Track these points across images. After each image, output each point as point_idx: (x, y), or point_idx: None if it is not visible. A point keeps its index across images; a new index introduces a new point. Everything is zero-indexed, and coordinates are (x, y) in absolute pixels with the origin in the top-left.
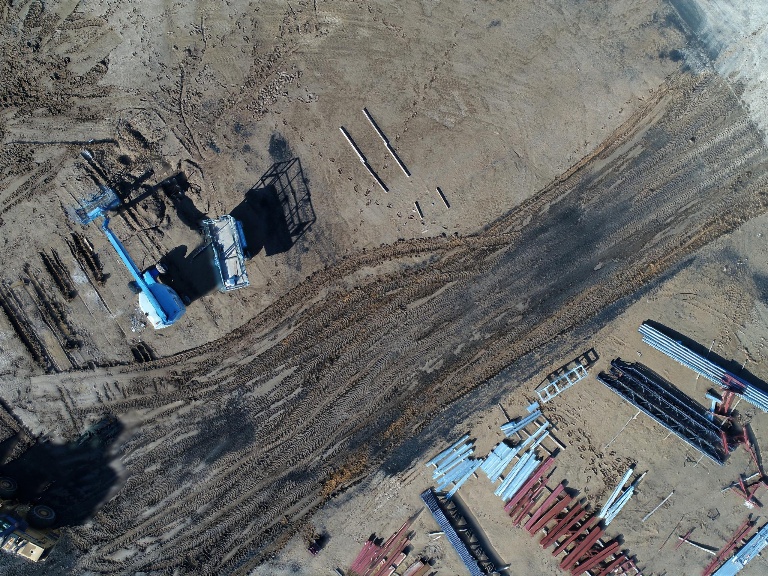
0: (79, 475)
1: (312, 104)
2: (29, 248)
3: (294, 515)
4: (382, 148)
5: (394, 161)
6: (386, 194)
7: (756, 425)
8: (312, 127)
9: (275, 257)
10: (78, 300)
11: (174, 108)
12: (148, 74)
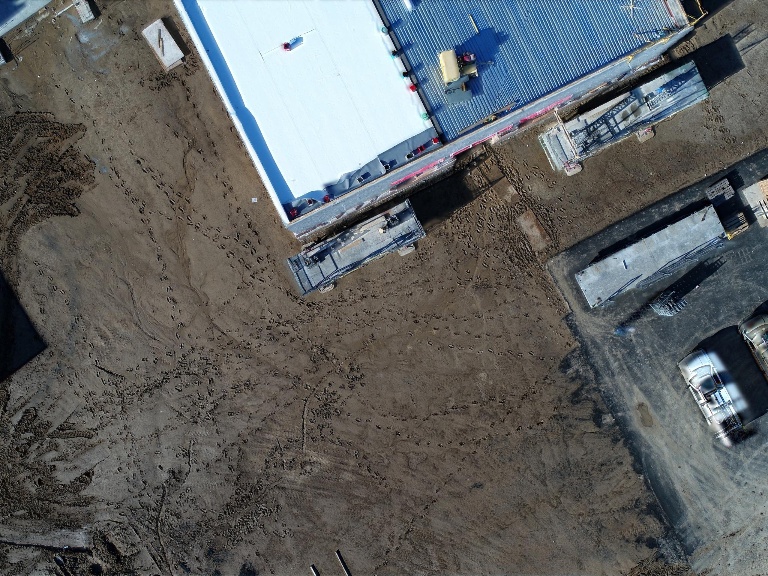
0: None
1: (287, 539)
2: None
3: None
4: None
5: None
6: None
7: None
8: (284, 561)
9: None
10: None
11: (151, 525)
12: (130, 490)
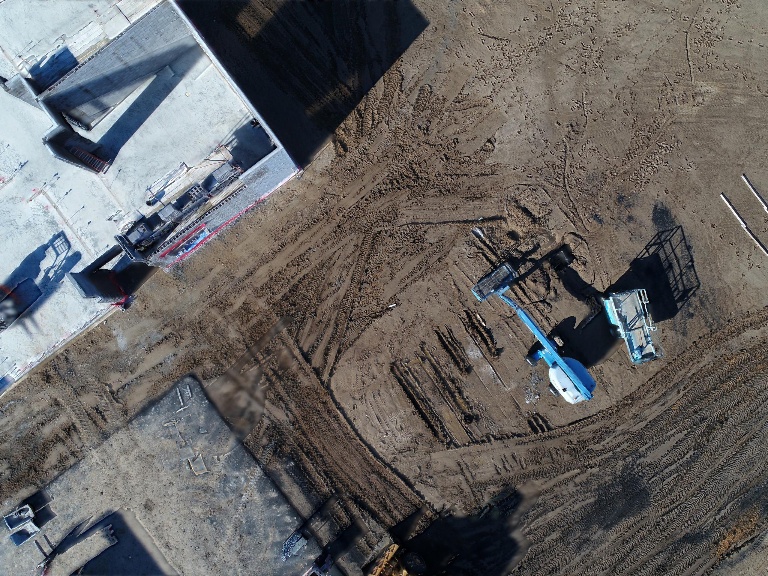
0: (481, 547)
1: (692, 172)
2: (425, 326)
3: None
4: (761, 212)
5: None
6: (767, 257)
7: None
8: (693, 195)
9: (661, 324)
10: (474, 375)
11: (559, 183)
12: (533, 151)
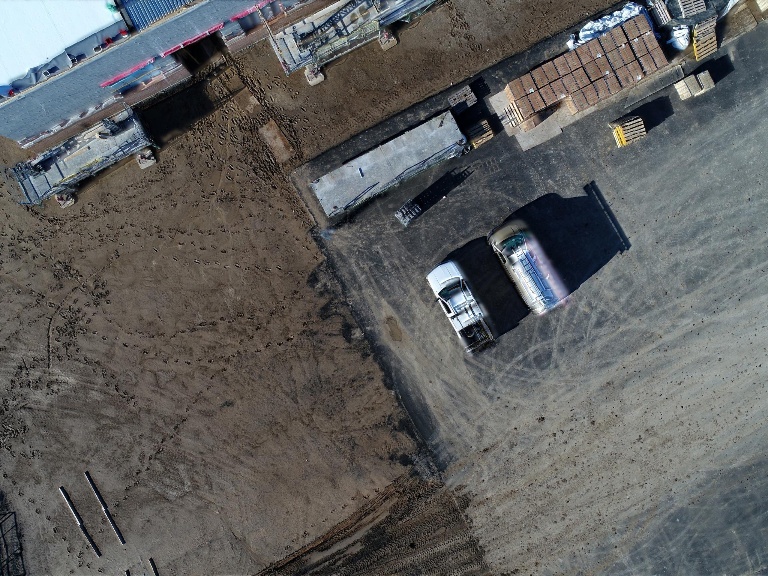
0: None
1: (35, 461)
2: None
3: None
4: (100, 512)
5: (110, 527)
6: (98, 558)
7: None
8: (32, 483)
9: None
10: None
11: None
12: None
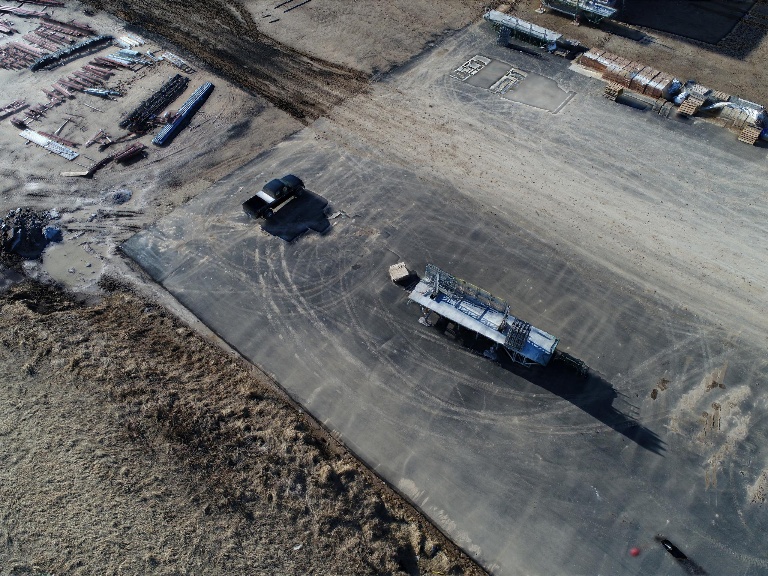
0: None
1: None
2: None
3: (105, 6)
4: (296, 5)
5: (290, 8)
6: (273, 8)
7: None
8: None
9: None
10: None
11: None
12: None
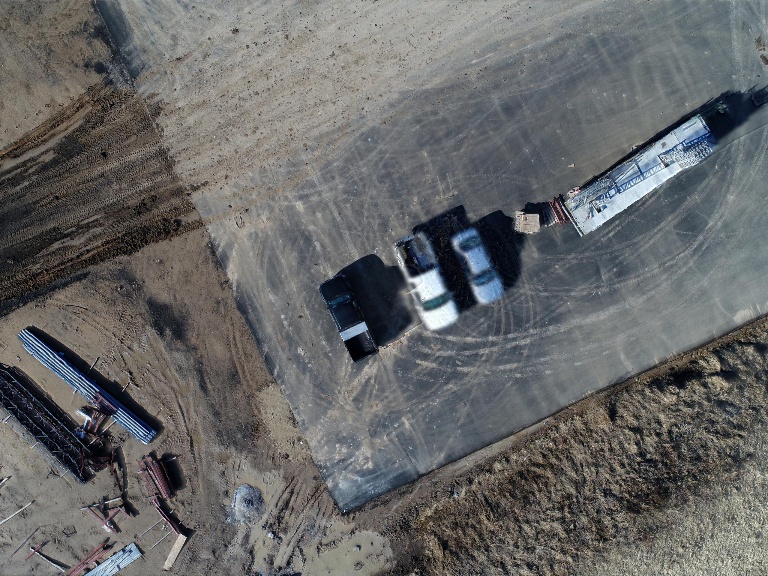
0: None
1: None
2: None
3: None
4: None
5: None
6: None
7: (128, 450)
8: None
9: None
10: None
11: None
12: None
